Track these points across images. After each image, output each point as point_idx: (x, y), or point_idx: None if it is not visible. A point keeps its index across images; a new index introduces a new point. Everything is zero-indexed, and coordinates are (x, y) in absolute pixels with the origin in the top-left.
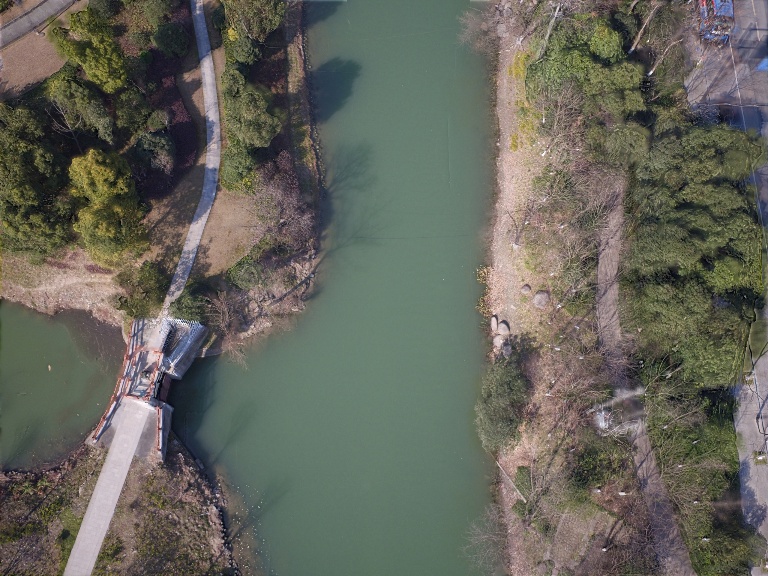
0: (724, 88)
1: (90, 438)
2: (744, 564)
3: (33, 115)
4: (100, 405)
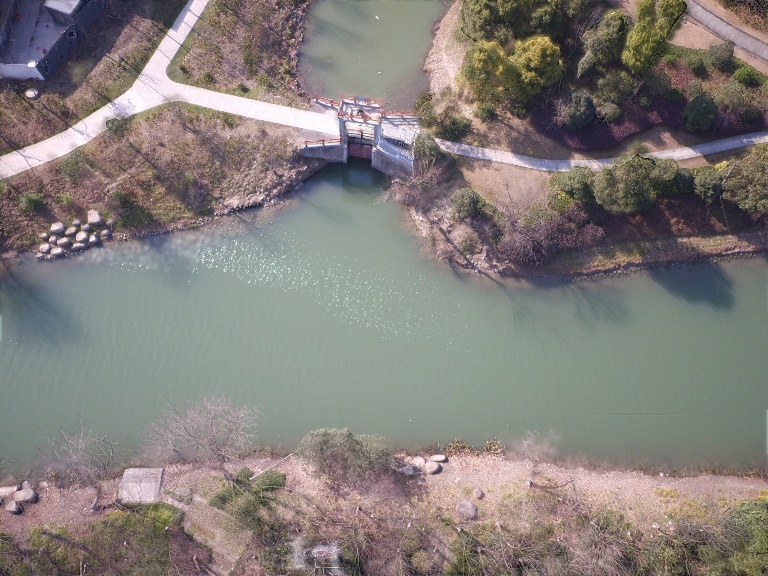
0: None
1: None
2: None
3: (585, 3)
4: None
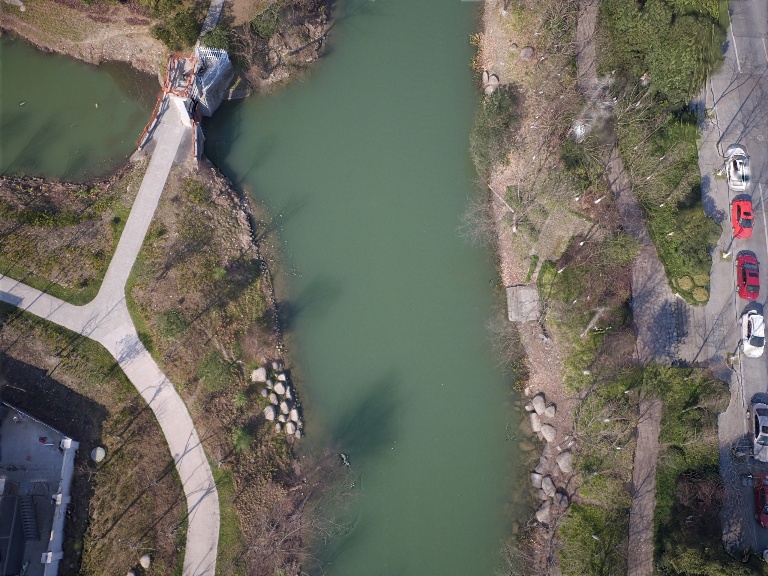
0: None
1: (134, 155)
2: (702, 243)
3: None
4: None
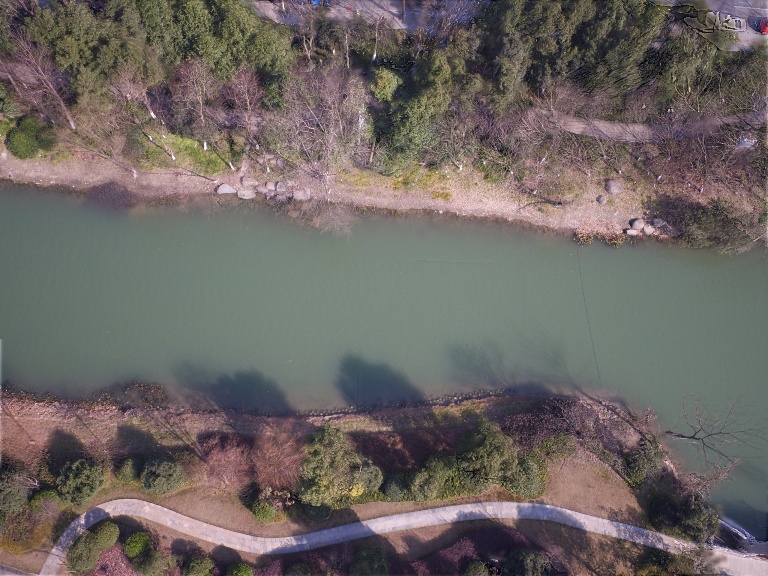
0: None
1: None
2: None
3: None
4: None
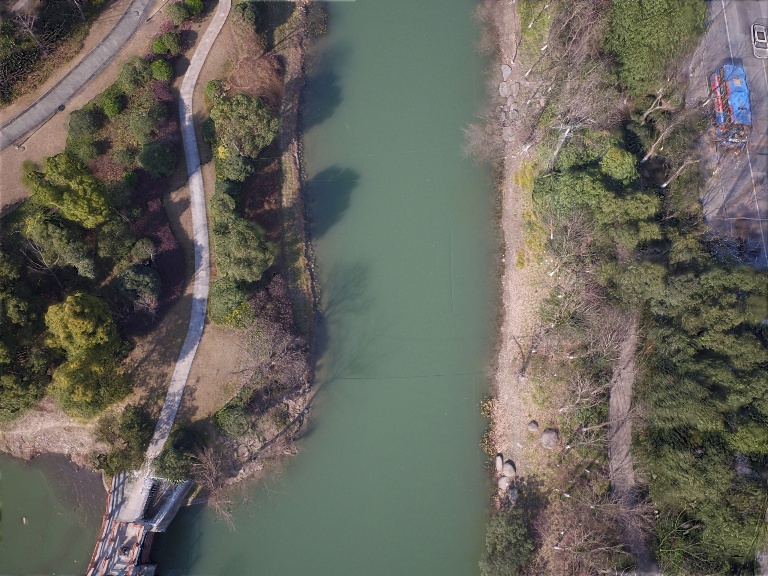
0: (741, 199)
1: None
2: None
3: (7, 258)
4: (78, 562)
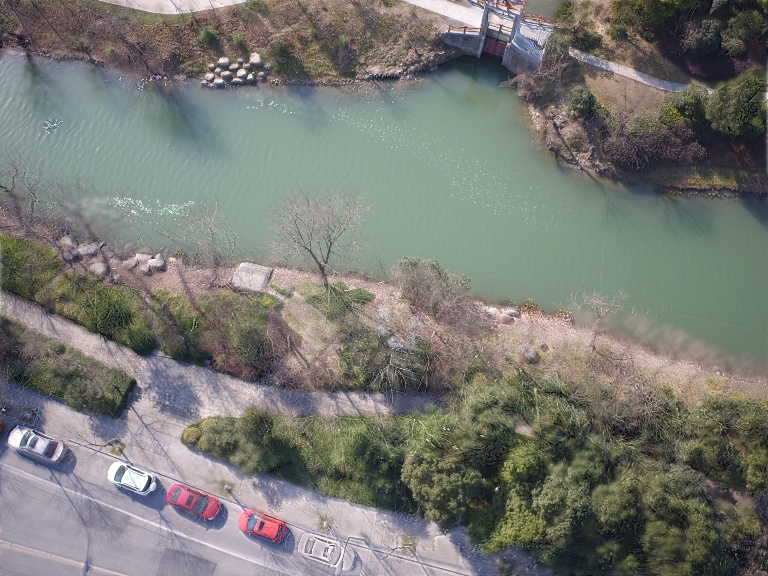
0: None
1: None
2: (237, 442)
3: None
4: None
